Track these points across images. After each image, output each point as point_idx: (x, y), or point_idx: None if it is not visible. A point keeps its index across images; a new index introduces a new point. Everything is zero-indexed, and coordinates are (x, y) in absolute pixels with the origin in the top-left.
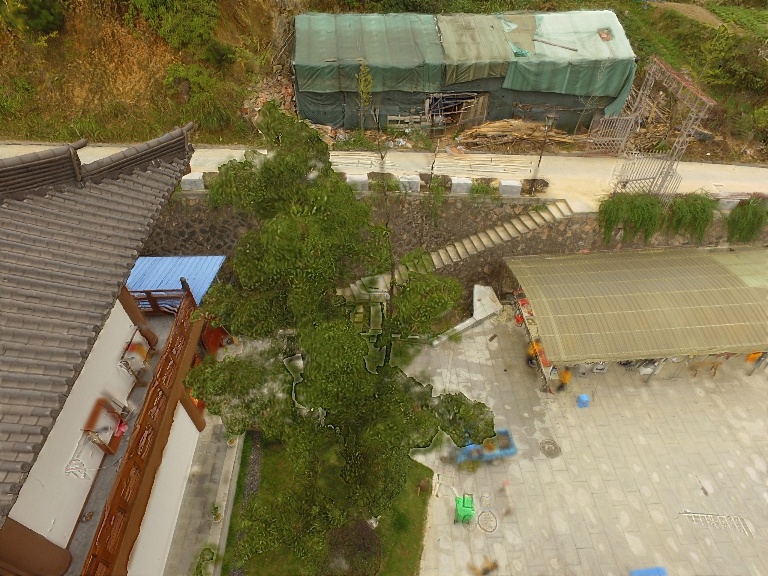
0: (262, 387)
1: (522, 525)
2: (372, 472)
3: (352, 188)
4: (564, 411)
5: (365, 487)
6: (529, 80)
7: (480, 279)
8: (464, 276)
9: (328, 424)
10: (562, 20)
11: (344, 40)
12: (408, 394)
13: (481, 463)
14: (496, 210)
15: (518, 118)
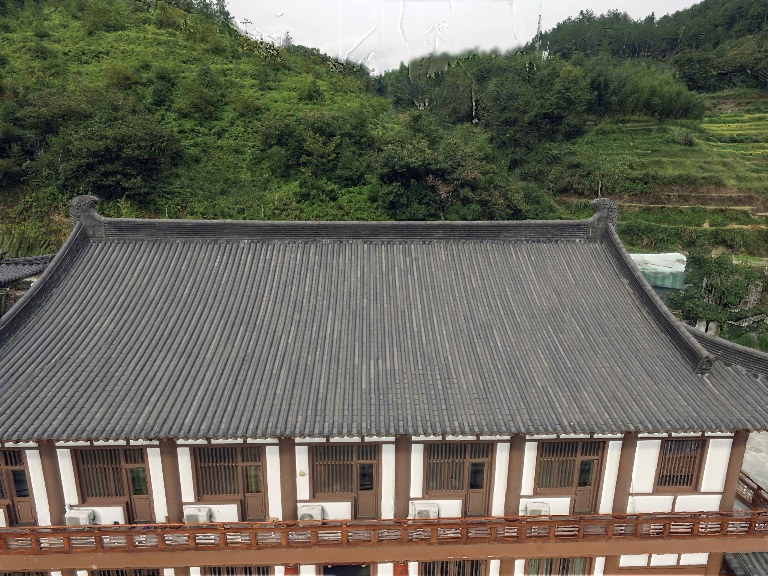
0: None
1: (764, 476)
2: None
3: None
4: (752, 436)
5: None
6: (651, 280)
7: None
8: None
9: None
10: (655, 256)
11: None
12: (734, 327)
13: None
14: None
15: None
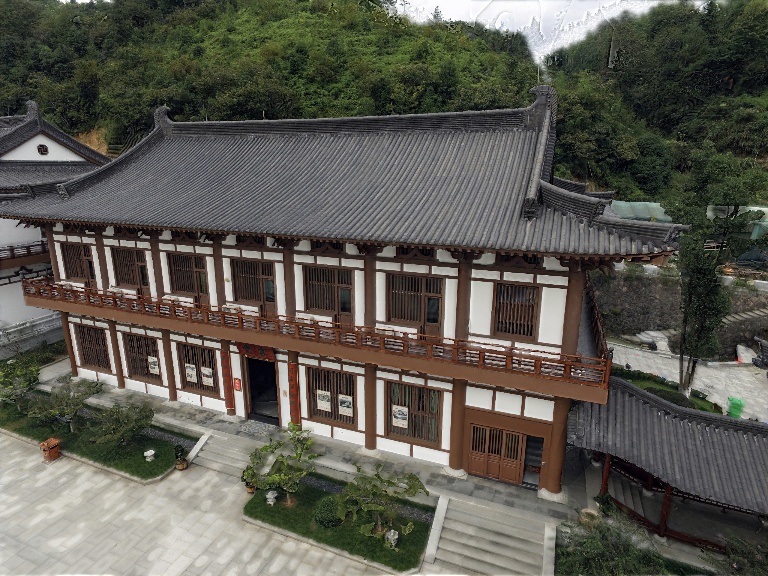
0: (695, 211)
1: None
2: (716, 290)
3: (646, 271)
4: None
5: (712, 295)
6: None
7: (742, 342)
8: (728, 337)
9: (684, 289)
10: None
11: (637, 210)
12: (741, 241)
13: (760, 413)
14: (752, 299)
15: (763, 261)
